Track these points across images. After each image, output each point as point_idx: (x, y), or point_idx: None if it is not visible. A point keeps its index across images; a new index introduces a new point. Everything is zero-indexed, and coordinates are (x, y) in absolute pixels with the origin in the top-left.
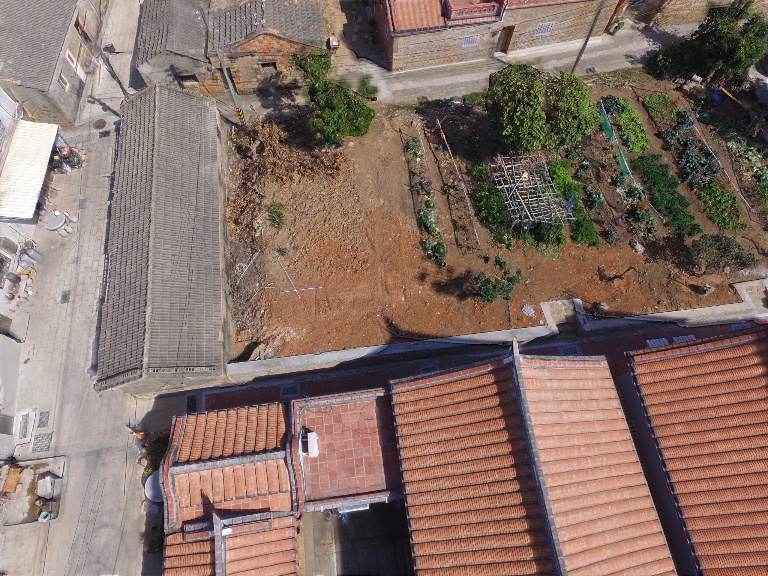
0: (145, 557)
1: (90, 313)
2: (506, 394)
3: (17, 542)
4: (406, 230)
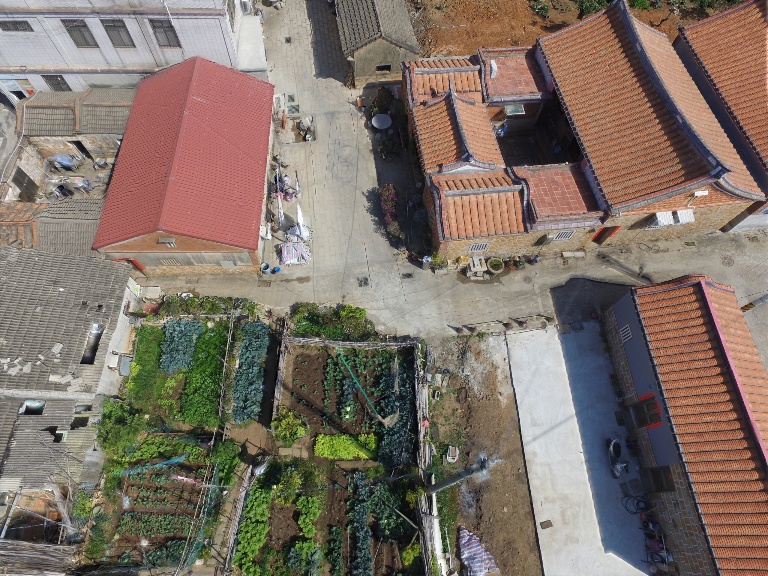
0: (376, 160)
1: (307, 48)
2: (615, 20)
3: (292, 151)
4: (519, 1)
